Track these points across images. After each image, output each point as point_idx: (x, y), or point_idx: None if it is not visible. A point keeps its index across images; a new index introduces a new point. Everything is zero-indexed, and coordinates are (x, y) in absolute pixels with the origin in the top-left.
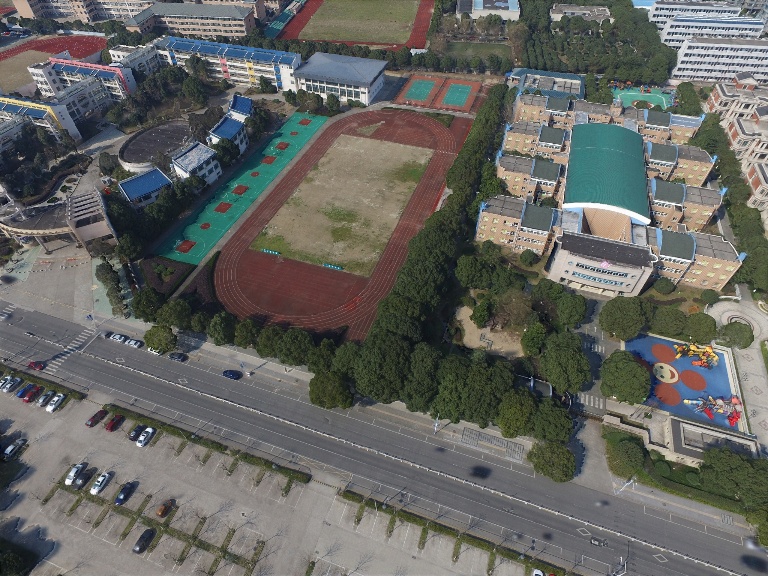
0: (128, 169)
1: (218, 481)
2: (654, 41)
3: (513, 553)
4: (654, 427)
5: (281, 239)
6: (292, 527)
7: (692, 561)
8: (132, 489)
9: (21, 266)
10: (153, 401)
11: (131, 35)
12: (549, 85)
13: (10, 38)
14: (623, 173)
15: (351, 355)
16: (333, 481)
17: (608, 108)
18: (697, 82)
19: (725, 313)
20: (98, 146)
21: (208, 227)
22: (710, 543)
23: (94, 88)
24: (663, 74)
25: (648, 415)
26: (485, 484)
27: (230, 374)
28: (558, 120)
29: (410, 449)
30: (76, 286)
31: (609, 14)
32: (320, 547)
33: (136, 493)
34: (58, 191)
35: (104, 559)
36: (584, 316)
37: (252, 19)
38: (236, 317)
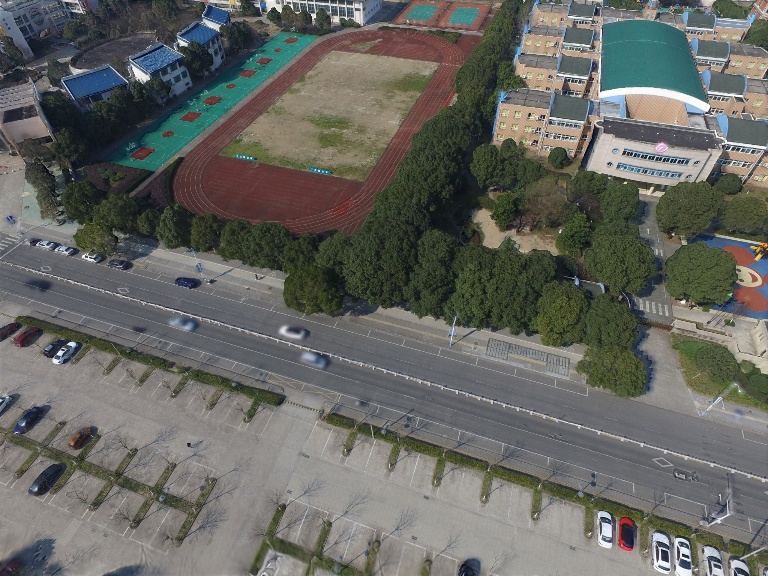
0: None
1: (158, 404)
2: None
3: (567, 490)
4: (740, 336)
5: (258, 145)
6: (256, 460)
7: None
8: (40, 415)
9: None
10: (82, 313)
11: None
12: (568, 2)
13: None
14: (670, 61)
15: (339, 244)
16: (314, 403)
17: (640, 14)
18: None
19: None
20: None
21: (171, 135)
22: None
23: (50, 4)
24: None
25: (730, 322)
26: (521, 404)
27: (184, 281)
28: None
29: (418, 364)
30: (3, 193)
31: None
32: (294, 485)
33: (45, 420)
34: None
35: None
36: (636, 210)
37: None
38: (194, 215)
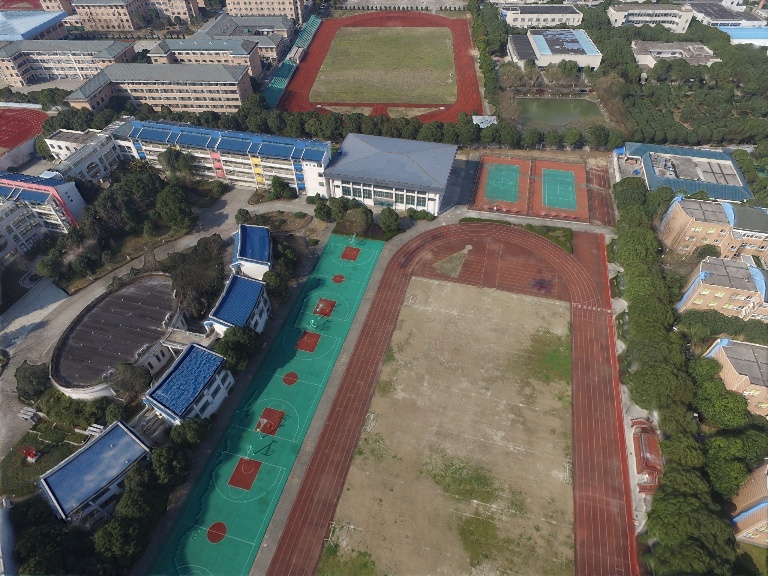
0: (68, 395)
1: None
2: None
3: None
4: None
5: (368, 564)
6: None
7: None
8: None
9: None
10: None
11: (77, 114)
12: (692, 171)
13: None
14: None
15: None
16: None
17: None
18: None
19: None
20: (21, 325)
21: (222, 536)
22: None
23: (16, 217)
24: None
25: None
26: None
27: None
28: (749, 242)
29: None
30: None
31: (712, 53)
32: None
33: None
34: None
35: None
36: None
37: (247, 80)
38: None
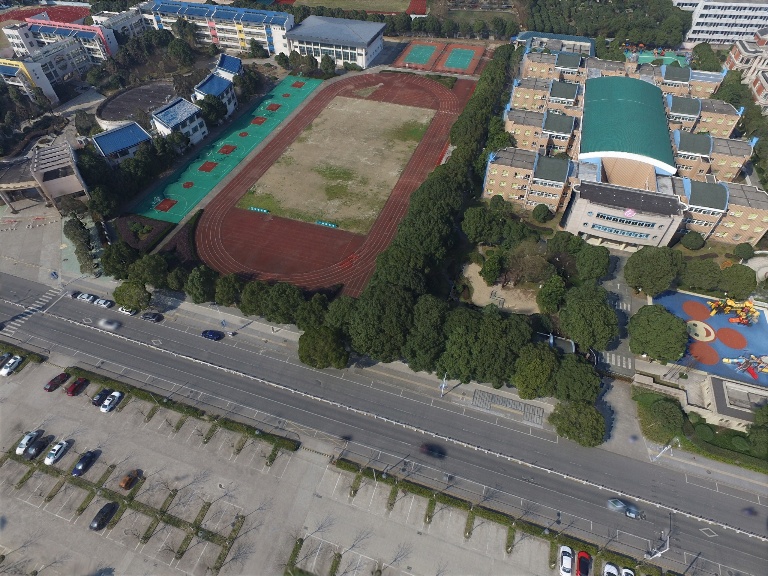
0: (106, 128)
1: (193, 449)
2: (666, 5)
3: (536, 527)
4: (691, 388)
5: (270, 197)
6: (277, 500)
7: (746, 535)
8: (93, 458)
9: None
10: (122, 363)
11: (115, 1)
12: (557, 47)
13: None
14: (644, 123)
15: (346, 308)
16: (325, 448)
17: (622, 65)
18: (713, 45)
19: (762, 269)
20: (76, 108)
21: (191, 186)
22: (765, 515)
23: (73, 50)
24: (678, 35)
25: (683, 375)
26: (500, 451)
27: (210, 334)
28: (569, 78)
29: (414, 413)
30: (43, 245)
31: None
32: (309, 522)
33: (97, 463)
34: (30, 151)
35: (56, 537)
36: (607, 270)
37: None
38: (218, 273)
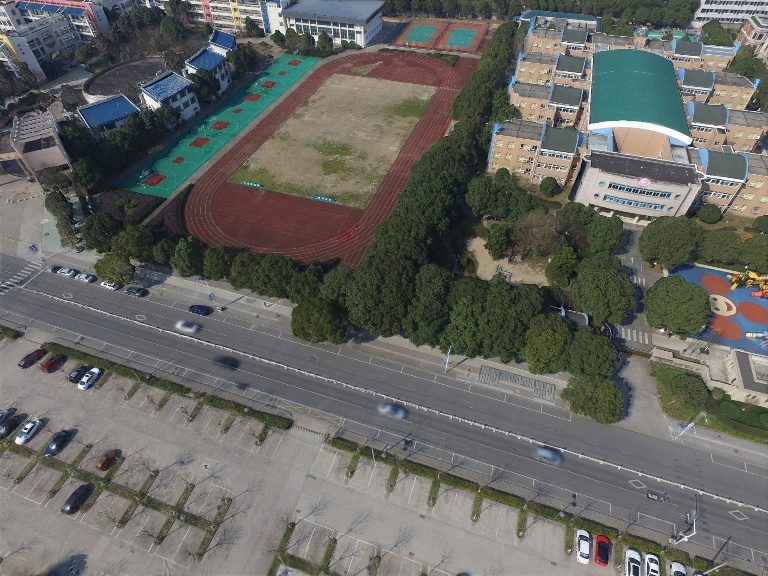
0: None
1: (176, 428)
2: None
3: (549, 510)
4: (713, 363)
5: (264, 172)
6: (267, 481)
7: None
8: (68, 438)
9: None
10: (103, 339)
11: None
12: (562, 25)
13: None
14: (656, 93)
15: (342, 278)
16: (320, 427)
17: (630, 40)
18: (723, 24)
19: None
20: None
21: (181, 161)
22: None
23: (61, 27)
24: (686, 13)
25: (705, 350)
26: (510, 429)
27: (197, 308)
28: (575, 54)
29: (415, 390)
30: (23, 220)
31: None
32: (302, 505)
33: (73, 442)
34: None
35: (24, 521)
36: (620, 242)
37: None
38: (206, 245)
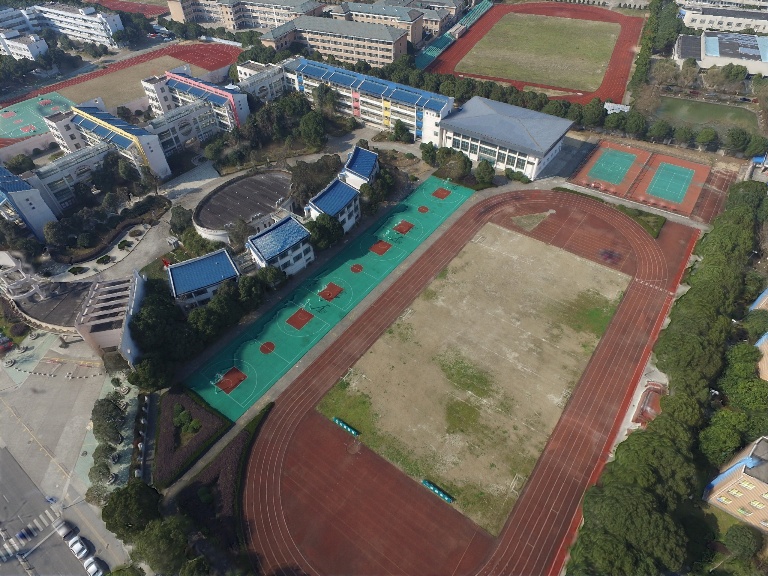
0: (200, 233)
1: None
2: None
3: None
4: None
5: (366, 403)
6: None
7: None
8: None
9: (26, 359)
10: None
11: (264, 50)
12: None
13: (155, 40)
14: None
15: None
16: None
17: None
18: None
19: None
20: (184, 187)
21: (270, 351)
22: None
23: (201, 113)
24: None
25: None
26: None
27: None
28: None
29: None
30: (71, 416)
31: None
32: None
33: None
34: (116, 246)
35: None
36: None
37: (404, 43)
38: None
